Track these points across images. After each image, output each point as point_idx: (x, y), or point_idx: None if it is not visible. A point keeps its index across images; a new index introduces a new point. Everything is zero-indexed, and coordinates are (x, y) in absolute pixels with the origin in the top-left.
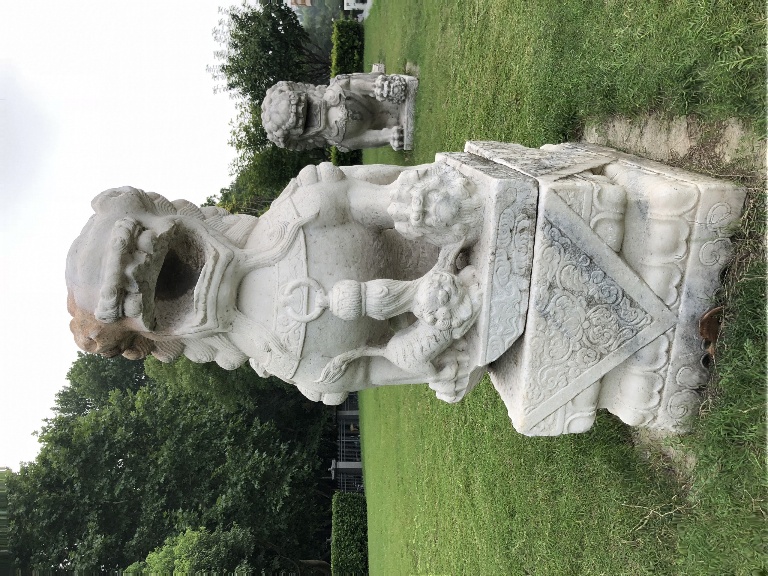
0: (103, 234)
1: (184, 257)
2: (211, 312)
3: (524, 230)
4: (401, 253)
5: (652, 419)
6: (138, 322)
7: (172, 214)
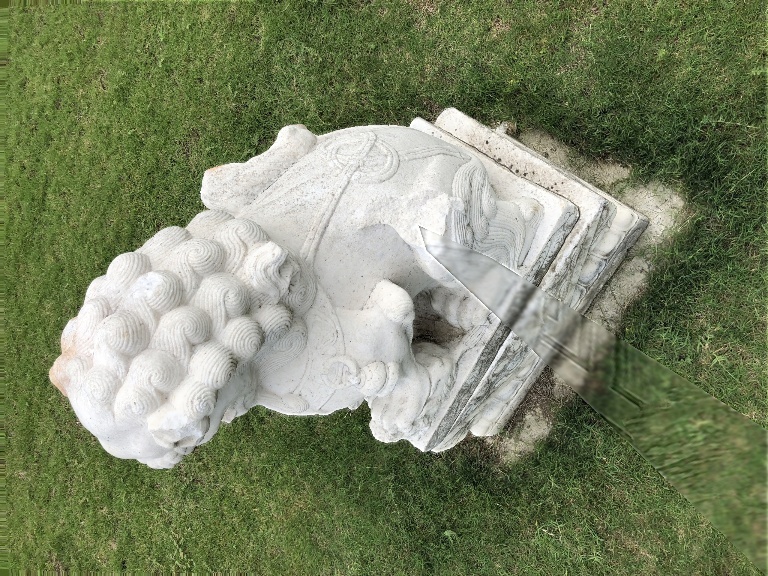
0: None
1: None
2: None
3: None
4: None
5: None
6: None
7: None
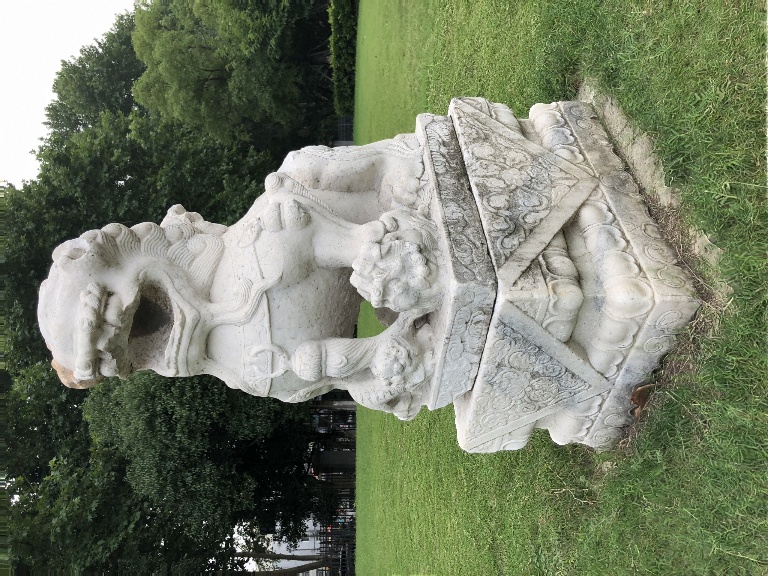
0: (70, 308)
1: (152, 298)
2: (182, 368)
3: (479, 322)
4: None
5: None
6: None
7: (136, 252)
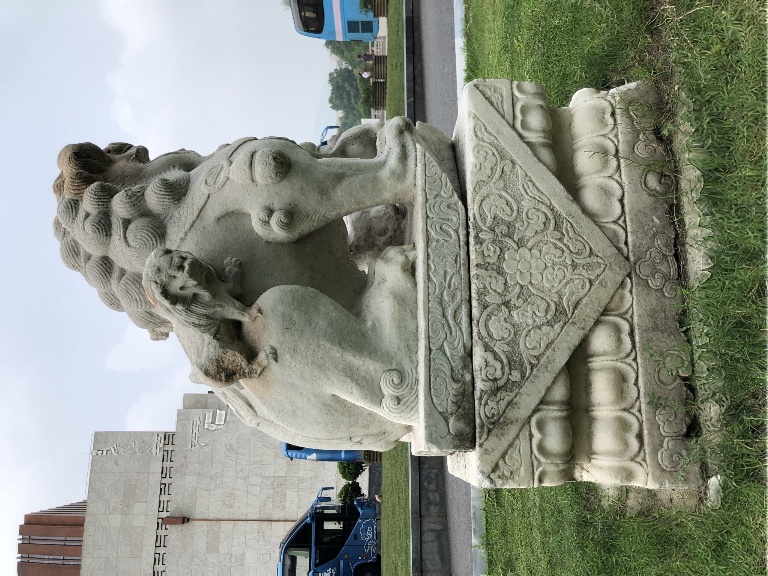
0: None
1: None
2: None
3: None
4: None
5: None
6: None
7: None
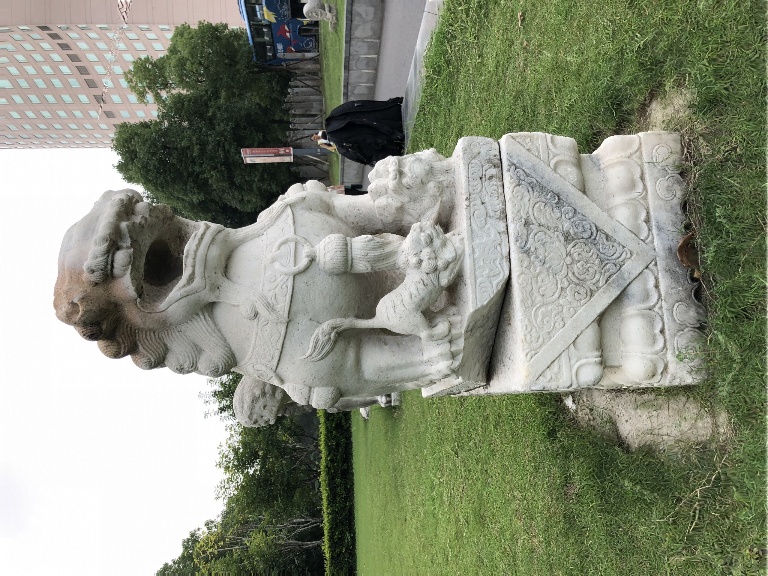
0: (103, 204)
1: (176, 252)
2: (199, 269)
3: (492, 177)
4: (386, 278)
5: (664, 369)
6: (125, 281)
7: None
